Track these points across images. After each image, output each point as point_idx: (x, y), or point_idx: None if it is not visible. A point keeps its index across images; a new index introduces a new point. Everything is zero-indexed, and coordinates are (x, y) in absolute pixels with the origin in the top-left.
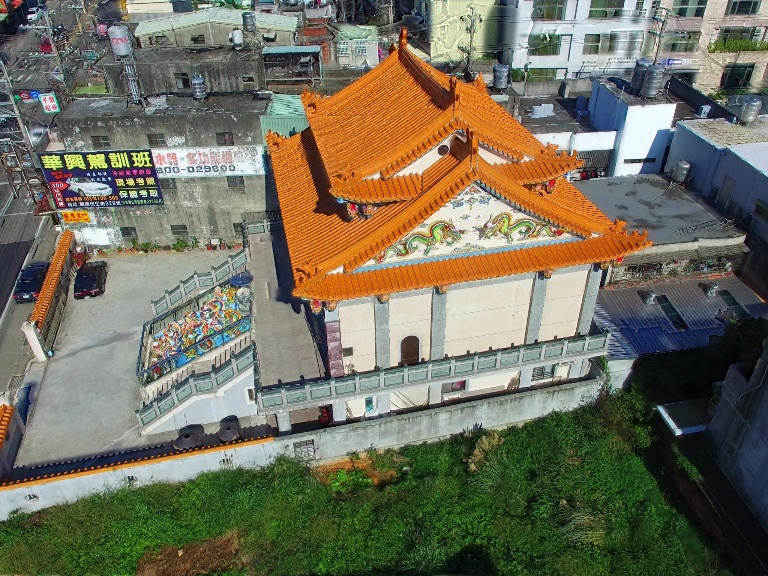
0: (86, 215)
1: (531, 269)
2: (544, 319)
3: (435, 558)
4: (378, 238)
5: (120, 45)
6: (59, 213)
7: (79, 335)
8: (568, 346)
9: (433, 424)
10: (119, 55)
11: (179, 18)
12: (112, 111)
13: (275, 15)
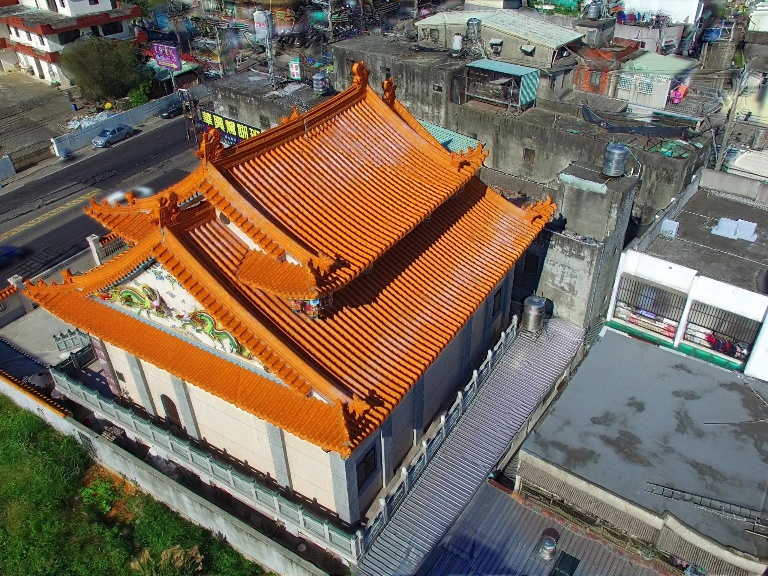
0: None
1: (215, 392)
2: (294, 467)
3: None
4: (105, 275)
5: (259, 29)
6: None
7: None
8: (305, 518)
9: (180, 499)
10: (258, 38)
11: (465, 14)
12: (250, 87)
13: (560, 27)
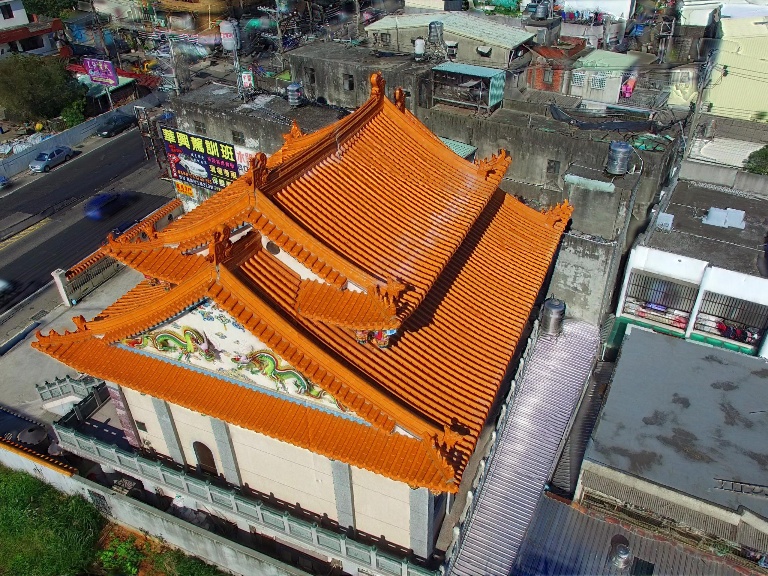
0: (191, 190)
1: (284, 438)
2: (360, 506)
3: None
4: (133, 320)
5: (226, 40)
6: (174, 182)
7: (108, 295)
8: (378, 559)
9: (219, 552)
10: (226, 49)
11: (414, 18)
12: (217, 101)
13: (511, 28)
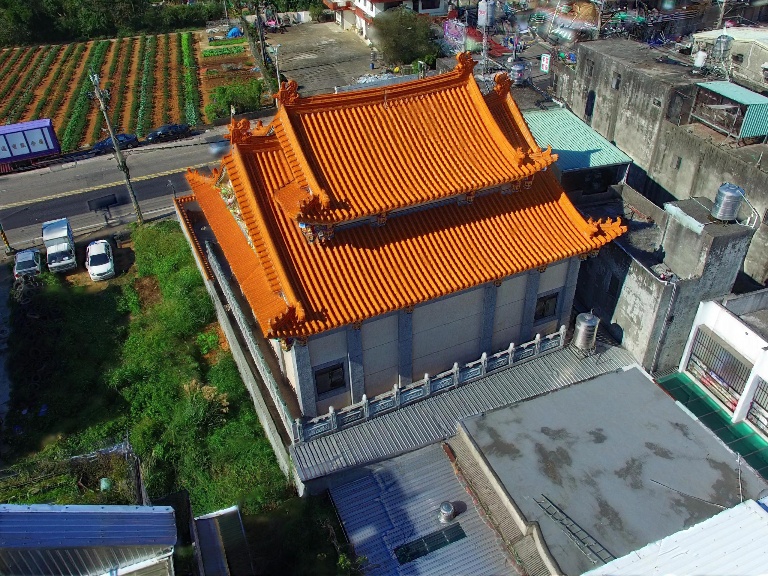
0: None
1: None
2: None
3: (112, 379)
4: None
5: (480, 16)
6: None
7: None
8: None
9: None
10: None
11: (754, 32)
12: None
13: None
